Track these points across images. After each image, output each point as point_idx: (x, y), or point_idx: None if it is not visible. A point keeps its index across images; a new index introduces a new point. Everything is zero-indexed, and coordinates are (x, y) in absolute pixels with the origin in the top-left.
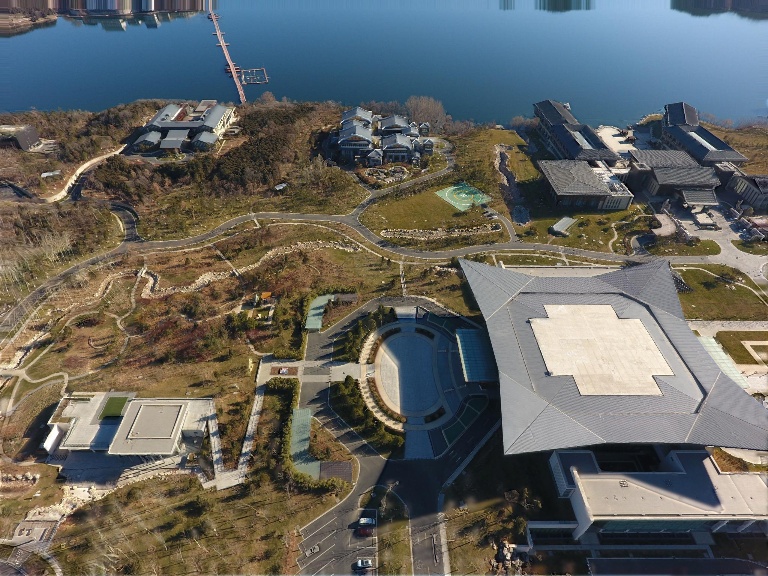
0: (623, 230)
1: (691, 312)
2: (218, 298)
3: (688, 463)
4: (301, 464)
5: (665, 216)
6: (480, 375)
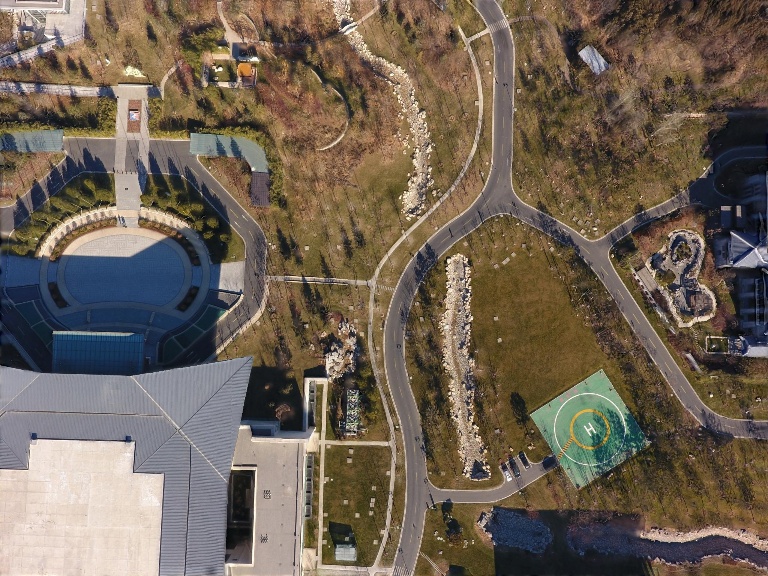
0: None
1: None
2: (276, 10)
3: None
4: (3, 145)
5: None
6: (61, 352)
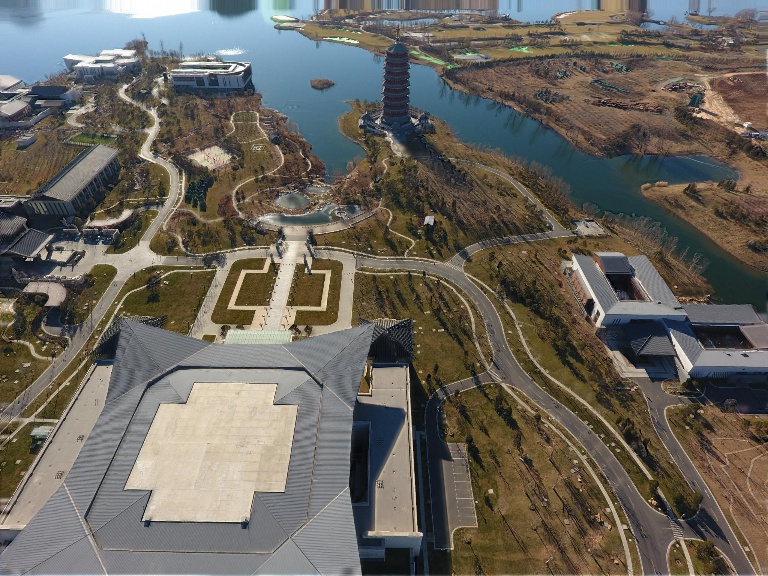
0: (23, 332)
1: (180, 328)
2: None
3: (361, 415)
4: None
5: (33, 284)
6: None
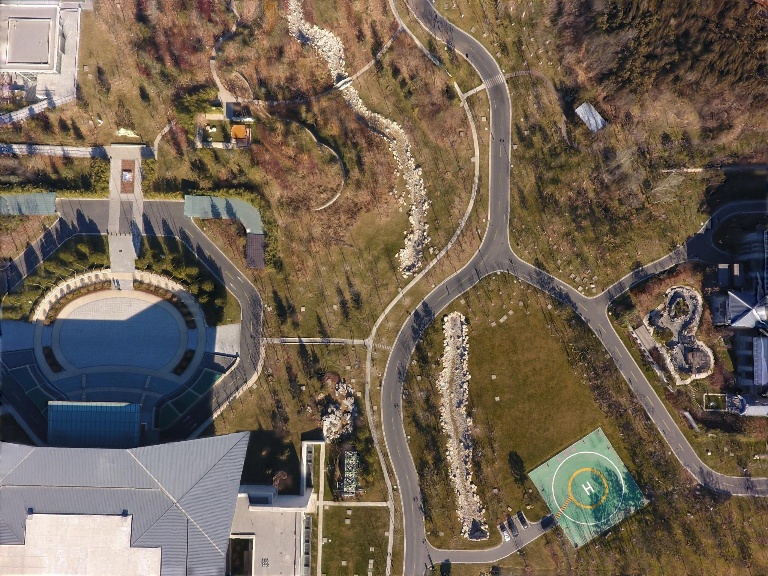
0: None
1: None
2: (270, 67)
3: None
4: None
5: None
6: (56, 422)
